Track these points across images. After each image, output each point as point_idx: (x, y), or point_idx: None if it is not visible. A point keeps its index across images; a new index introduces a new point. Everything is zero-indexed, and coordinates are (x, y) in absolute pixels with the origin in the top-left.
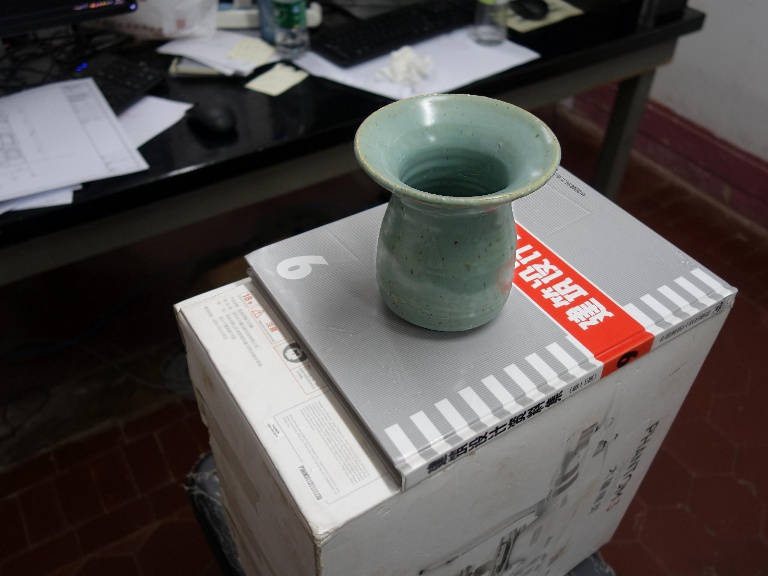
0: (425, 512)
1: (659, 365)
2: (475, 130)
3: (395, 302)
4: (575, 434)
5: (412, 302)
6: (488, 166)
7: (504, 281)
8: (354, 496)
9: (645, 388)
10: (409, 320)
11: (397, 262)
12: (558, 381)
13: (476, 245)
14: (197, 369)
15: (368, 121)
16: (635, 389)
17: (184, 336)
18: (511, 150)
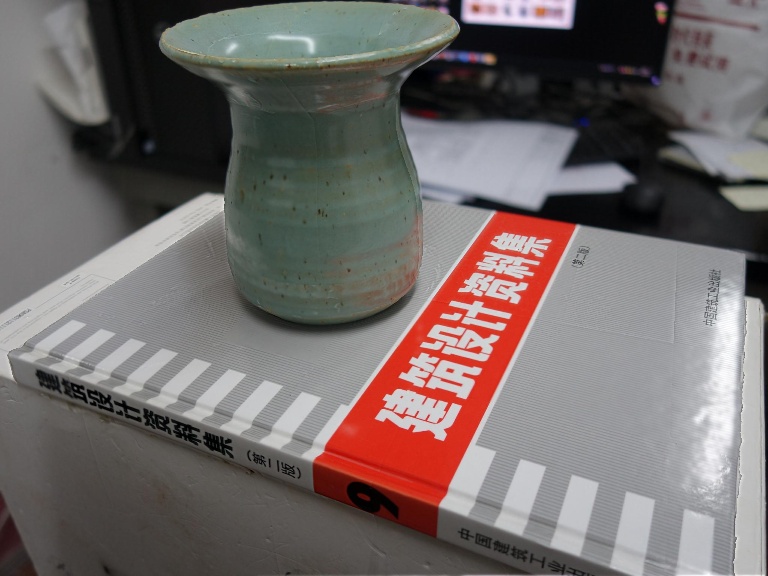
0: (64, 455)
1: None
2: None
3: None
4: (301, 575)
5: None
6: None
7: (301, 258)
8: (1, 354)
9: None
10: None
11: None
12: (242, 426)
13: (254, 166)
14: None
15: (302, 4)
16: None
17: None
18: None
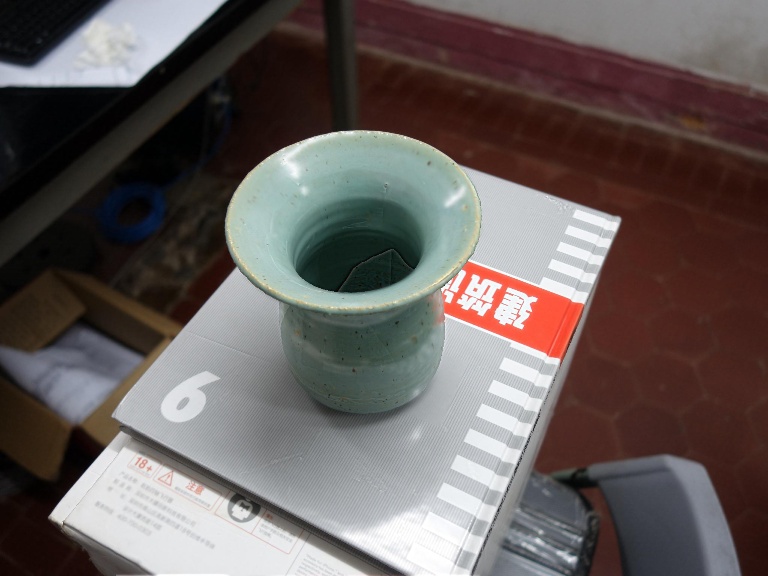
0: None
1: (582, 320)
2: (349, 175)
3: (337, 402)
4: (542, 426)
5: (361, 397)
6: (379, 211)
7: (443, 327)
8: None
9: (574, 345)
10: (359, 413)
11: (330, 365)
12: (532, 401)
13: (417, 314)
14: (118, 574)
15: (231, 222)
16: (570, 353)
17: (81, 545)
18: (404, 188)
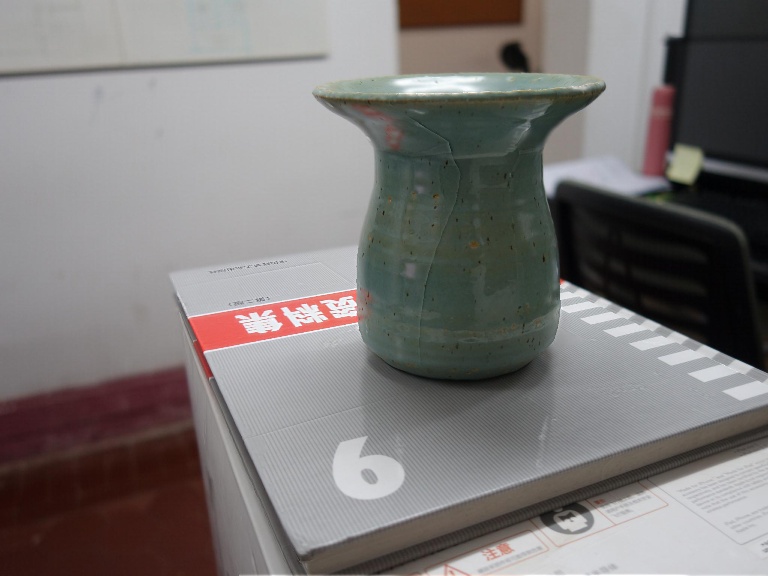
0: None
1: None
2: None
3: (531, 335)
4: None
5: (550, 308)
6: None
7: None
8: None
9: None
10: (544, 347)
11: (524, 264)
12: (598, 303)
13: None
14: None
15: None
16: None
17: None
18: None
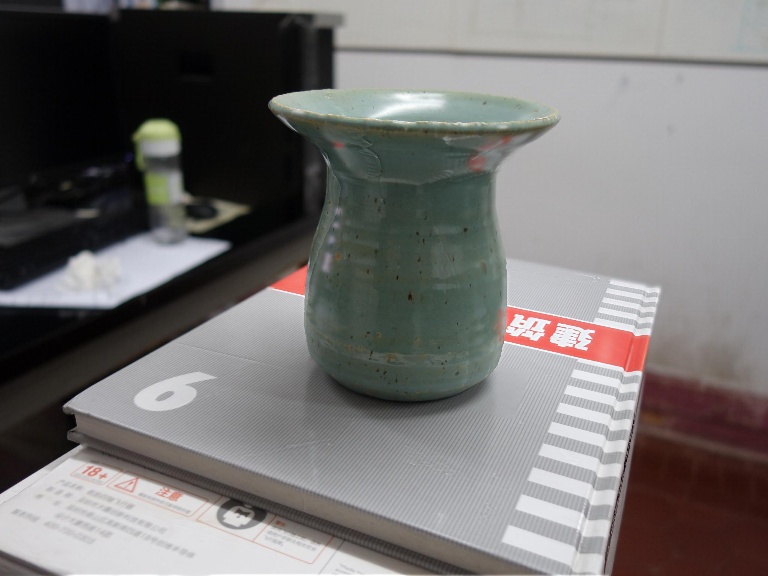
0: None
1: None
2: None
3: (381, 366)
4: None
5: (414, 350)
6: None
7: None
8: None
9: None
10: (408, 388)
11: (379, 292)
12: (622, 403)
13: (486, 232)
14: None
15: (277, 101)
16: None
17: None
18: None
